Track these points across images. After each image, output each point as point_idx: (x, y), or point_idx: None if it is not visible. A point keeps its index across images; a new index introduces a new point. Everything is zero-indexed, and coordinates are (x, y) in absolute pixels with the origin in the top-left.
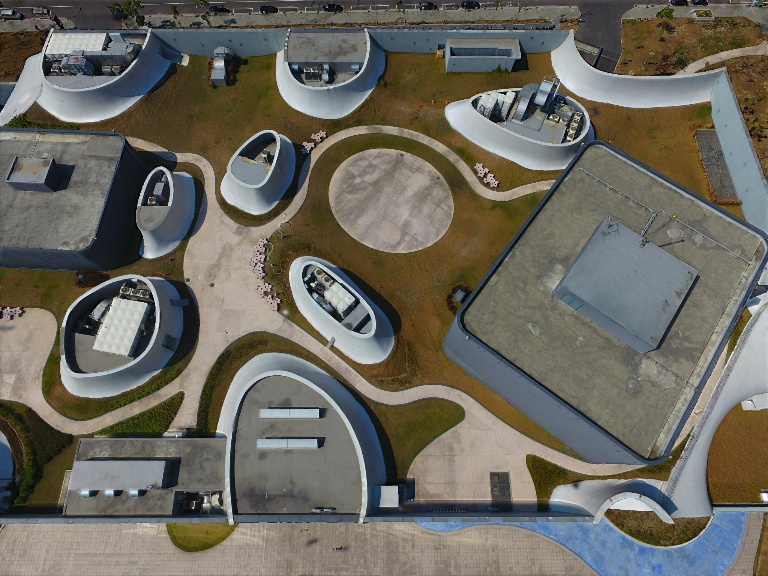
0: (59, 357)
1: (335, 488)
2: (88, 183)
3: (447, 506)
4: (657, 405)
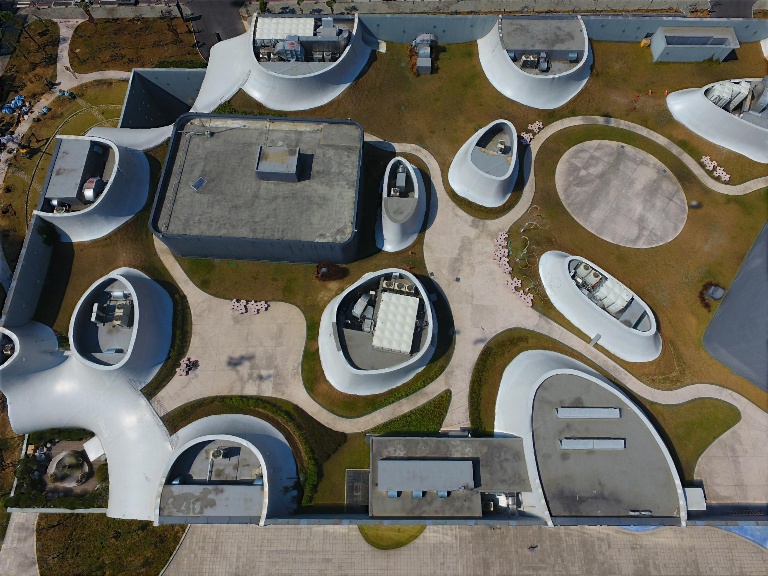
0: (317, 353)
1: (647, 490)
2: (331, 173)
3: (741, 509)
4: None
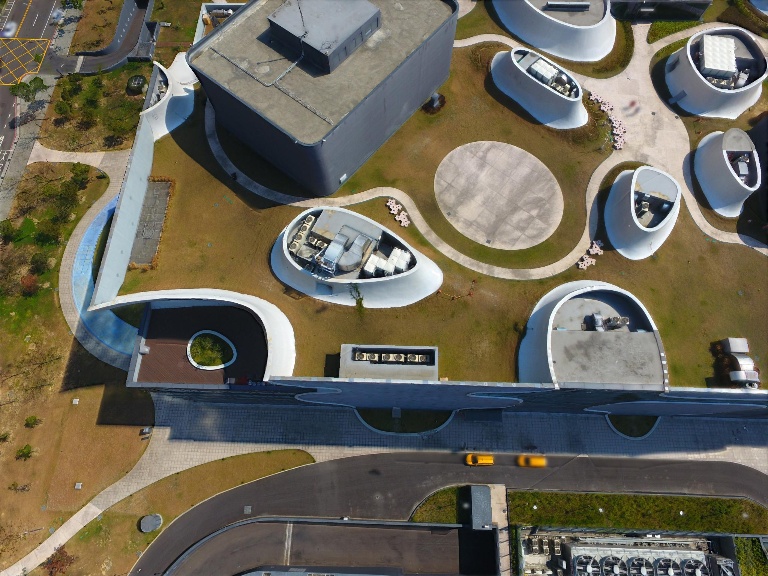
0: None
1: None
2: None
3: None
4: None
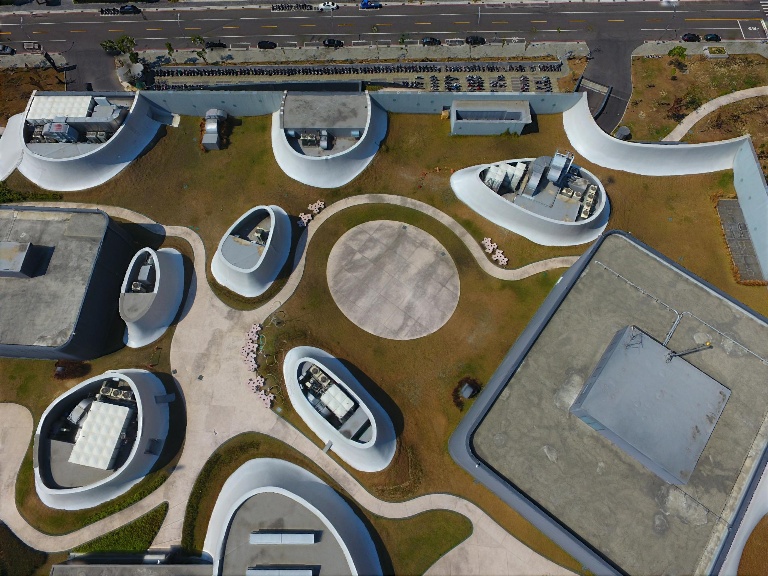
0: None
1: None
2: (68, 268)
3: None
4: (687, 546)
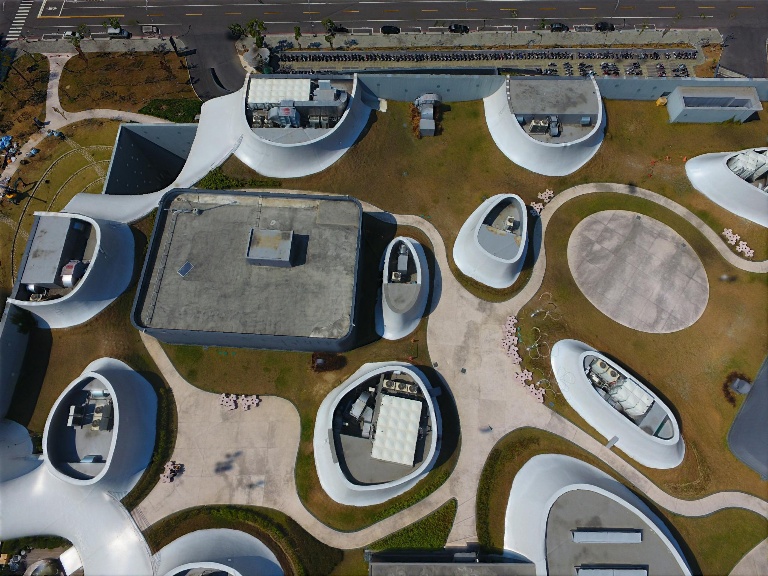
0: (312, 456)
1: None
2: (327, 257)
3: None
4: None
